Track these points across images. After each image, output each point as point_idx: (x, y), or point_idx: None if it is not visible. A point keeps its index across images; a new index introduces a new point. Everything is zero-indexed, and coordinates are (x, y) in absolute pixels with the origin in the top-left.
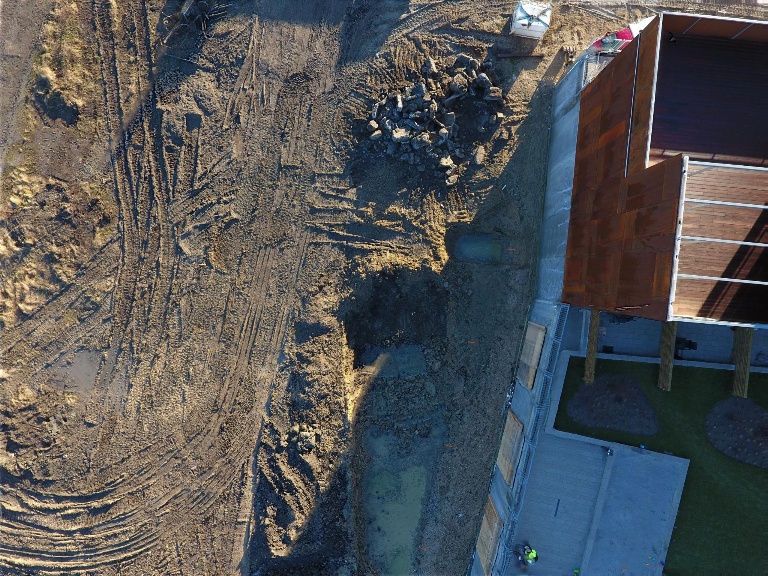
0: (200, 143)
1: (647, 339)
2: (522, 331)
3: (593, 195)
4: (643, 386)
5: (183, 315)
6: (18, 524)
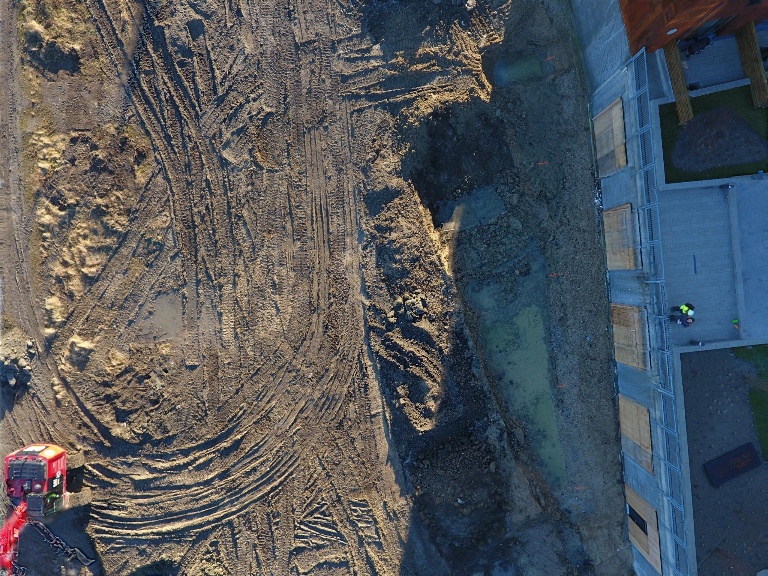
0: (210, 48)
1: (728, 66)
2: (589, 132)
3: None
4: (740, 114)
5: (249, 225)
6: (153, 492)
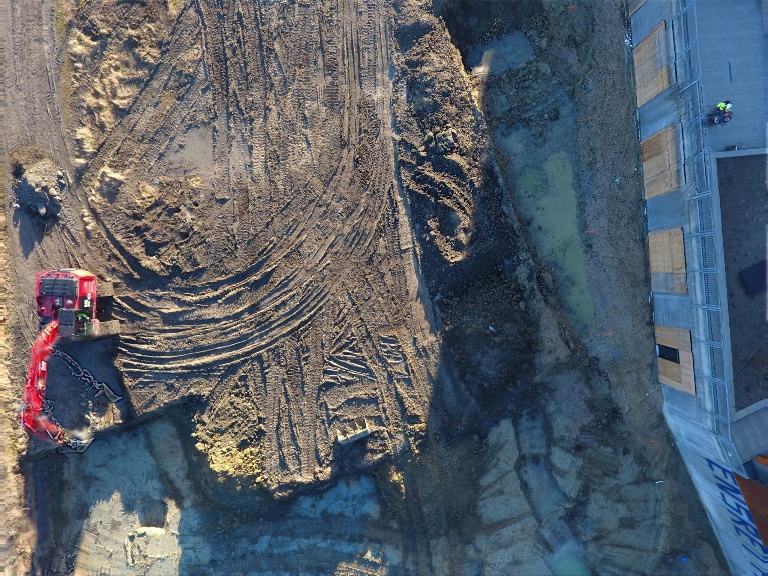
0: None
1: None
2: None
3: None
4: None
5: (281, 59)
6: (182, 326)
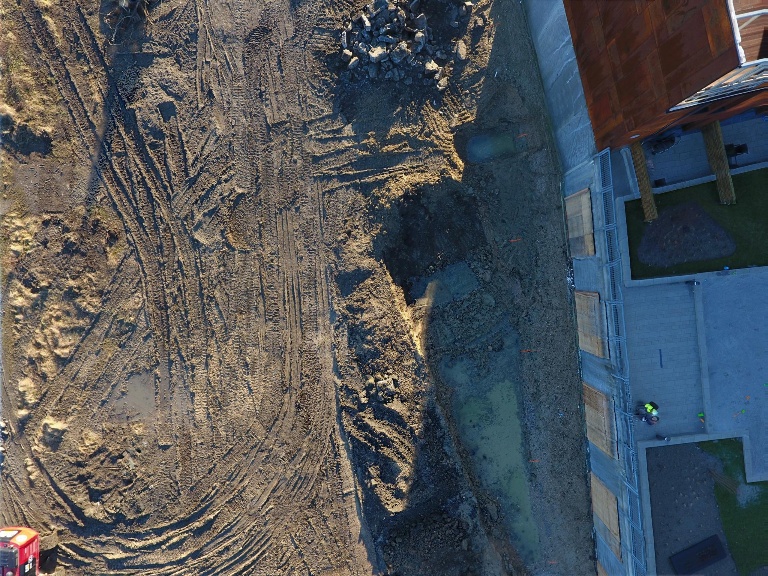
0: (181, 130)
1: (695, 161)
2: (561, 211)
3: (600, 22)
4: (706, 209)
5: (221, 306)
6: (126, 571)
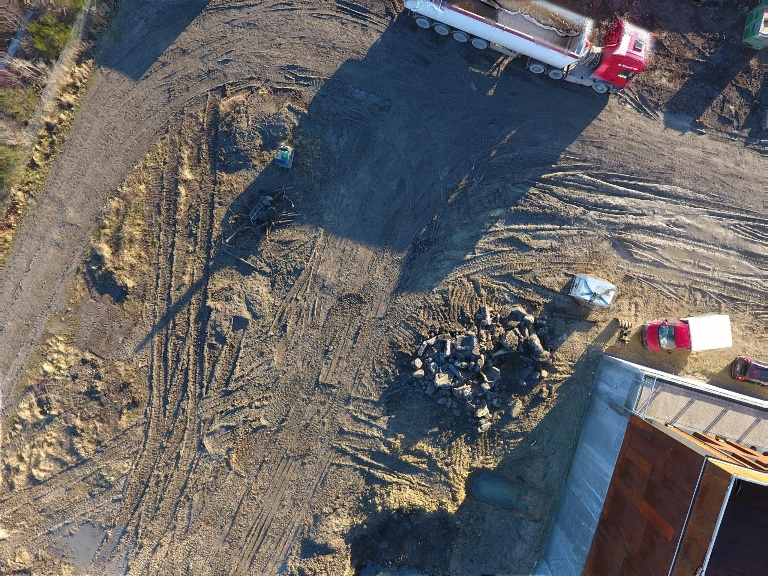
0: (243, 345)
1: None
2: None
3: (625, 550)
4: None
5: (194, 510)
6: None
